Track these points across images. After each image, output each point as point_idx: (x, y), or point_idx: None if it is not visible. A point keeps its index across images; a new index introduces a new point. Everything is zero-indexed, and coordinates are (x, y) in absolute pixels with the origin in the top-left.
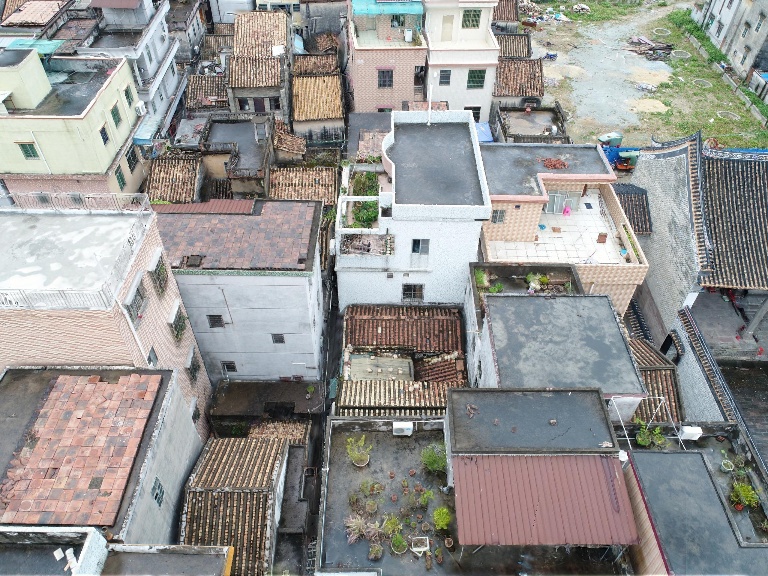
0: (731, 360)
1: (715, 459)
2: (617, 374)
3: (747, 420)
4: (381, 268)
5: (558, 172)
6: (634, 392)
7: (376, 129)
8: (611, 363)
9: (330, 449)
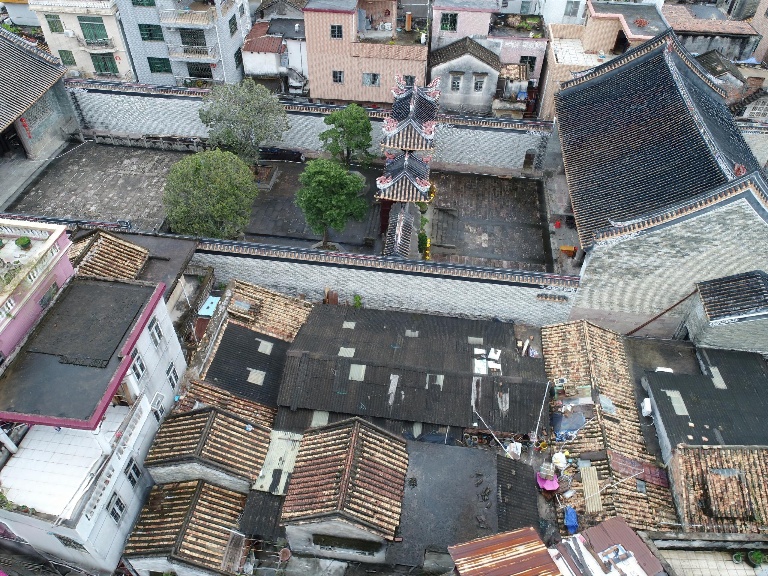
0: (546, 211)
1: None
2: (445, 4)
3: (489, 199)
4: (540, 6)
5: (630, 23)
6: (435, 5)
7: (692, 10)
8: (452, 4)
9: None
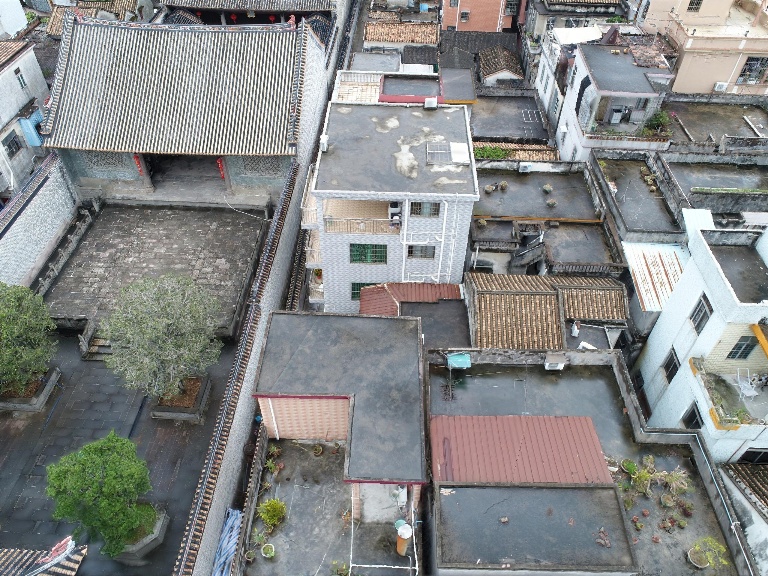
0: None
1: (272, 568)
2: None
3: None
4: None
5: None
6: None
7: None
8: None
9: (739, 575)
